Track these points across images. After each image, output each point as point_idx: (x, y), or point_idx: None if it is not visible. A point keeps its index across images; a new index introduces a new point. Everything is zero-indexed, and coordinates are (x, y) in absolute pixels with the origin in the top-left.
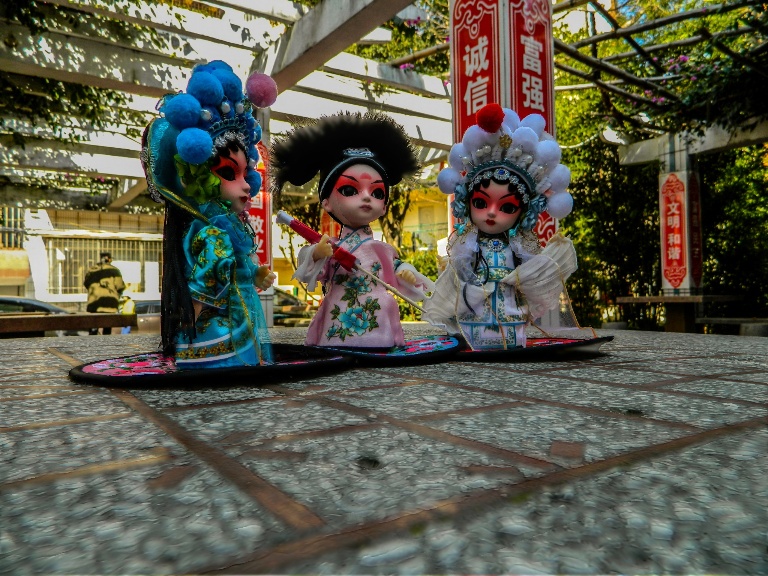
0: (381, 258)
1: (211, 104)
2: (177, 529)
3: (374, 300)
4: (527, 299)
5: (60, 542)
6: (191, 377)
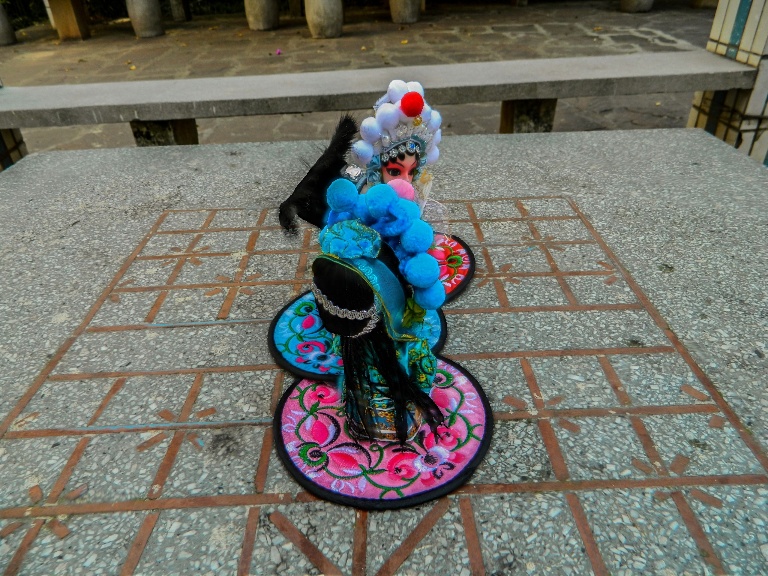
0: None
1: None
2: None
3: None
4: None
5: (764, 534)
6: None
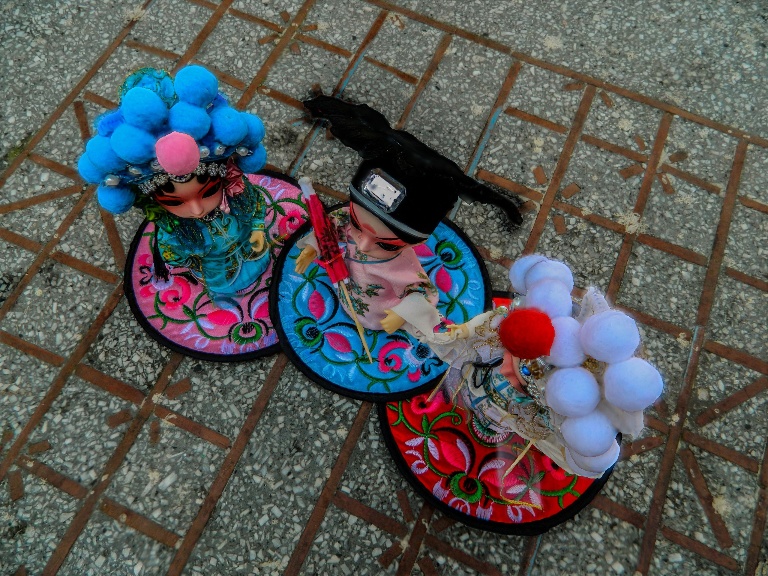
0: None
1: None
2: None
3: (364, 304)
4: None
5: None
6: None
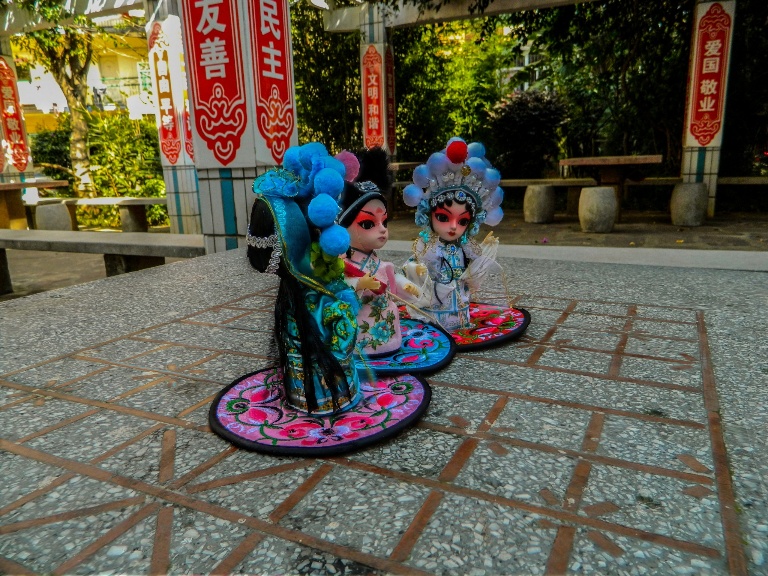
0: (387, 275)
1: (336, 197)
2: (675, 573)
3: (391, 313)
4: (468, 286)
5: None
6: (387, 436)
